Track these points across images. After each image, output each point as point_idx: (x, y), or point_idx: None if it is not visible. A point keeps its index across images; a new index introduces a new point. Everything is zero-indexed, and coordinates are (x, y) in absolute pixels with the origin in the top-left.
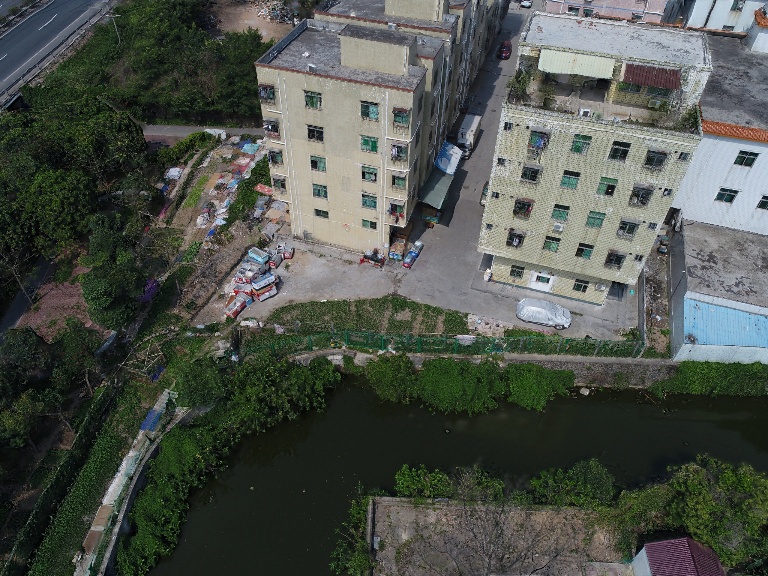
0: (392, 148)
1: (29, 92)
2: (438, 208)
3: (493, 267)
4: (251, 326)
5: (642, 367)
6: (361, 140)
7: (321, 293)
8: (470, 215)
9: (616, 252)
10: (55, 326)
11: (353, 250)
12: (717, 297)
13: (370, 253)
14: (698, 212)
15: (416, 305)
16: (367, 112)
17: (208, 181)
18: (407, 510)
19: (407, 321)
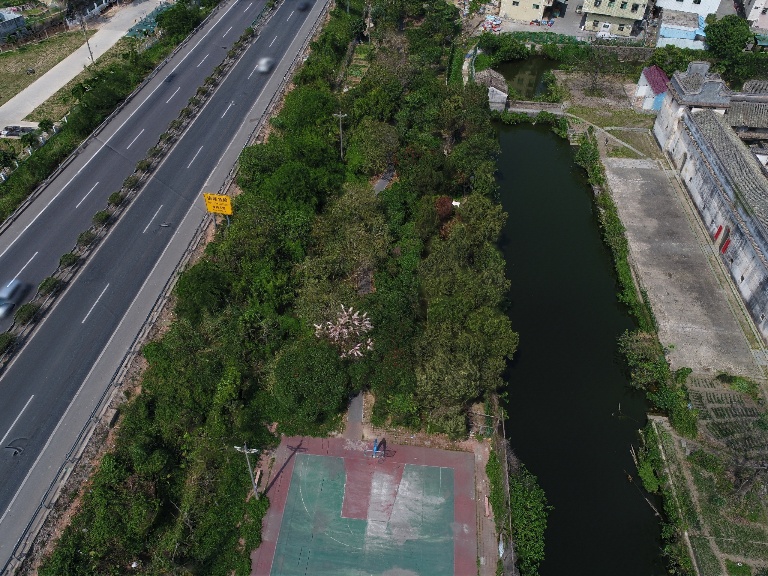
0: None
1: None
2: None
3: (586, 22)
4: (497, 34)
5: (644, 50)
6: None
7: None
8: (572, 15)
9: (636, 3)
10: None
11: (526, 21)
12: (673, 25)
13: (535, 20)
14: (670, 8)
15: None
16: None
17: None
18: (563, 75)
19: (554, 37)
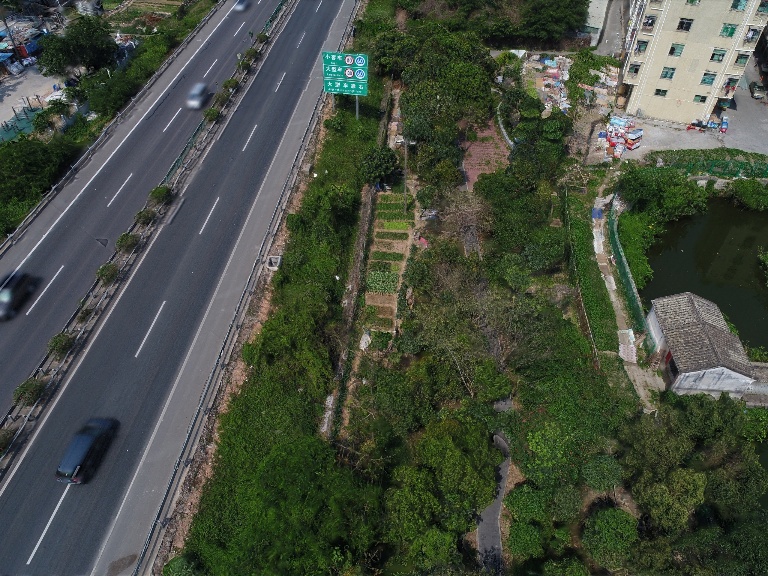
0: (749, 32)
1: (361, 25)
2: (746, 89)
3: None
4: None
5: None
6: (722, 28)
7: (670, 146)
8: (748, 104)
9: None
10: (491, 164)
11: (677, 122)
12: None
13: (696, 122)
14: None
15: (746, 152)
16: (737, 5)
17: (536, 83)
18: None
19: None
